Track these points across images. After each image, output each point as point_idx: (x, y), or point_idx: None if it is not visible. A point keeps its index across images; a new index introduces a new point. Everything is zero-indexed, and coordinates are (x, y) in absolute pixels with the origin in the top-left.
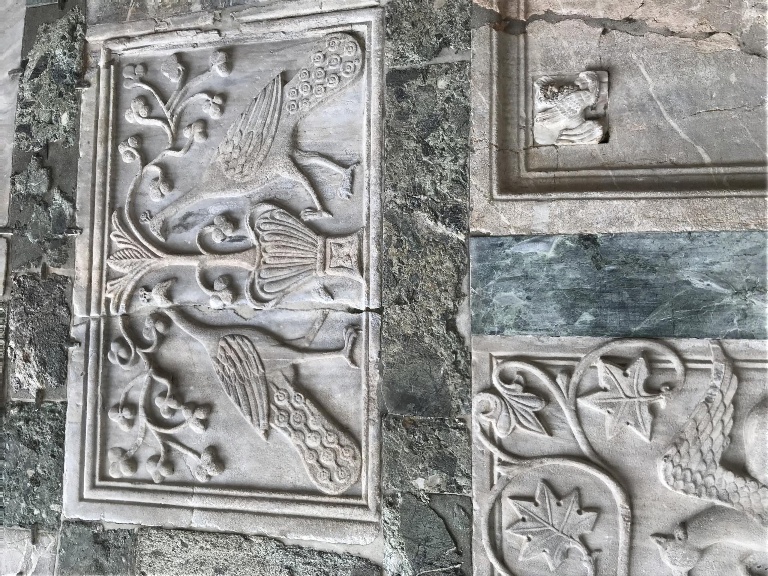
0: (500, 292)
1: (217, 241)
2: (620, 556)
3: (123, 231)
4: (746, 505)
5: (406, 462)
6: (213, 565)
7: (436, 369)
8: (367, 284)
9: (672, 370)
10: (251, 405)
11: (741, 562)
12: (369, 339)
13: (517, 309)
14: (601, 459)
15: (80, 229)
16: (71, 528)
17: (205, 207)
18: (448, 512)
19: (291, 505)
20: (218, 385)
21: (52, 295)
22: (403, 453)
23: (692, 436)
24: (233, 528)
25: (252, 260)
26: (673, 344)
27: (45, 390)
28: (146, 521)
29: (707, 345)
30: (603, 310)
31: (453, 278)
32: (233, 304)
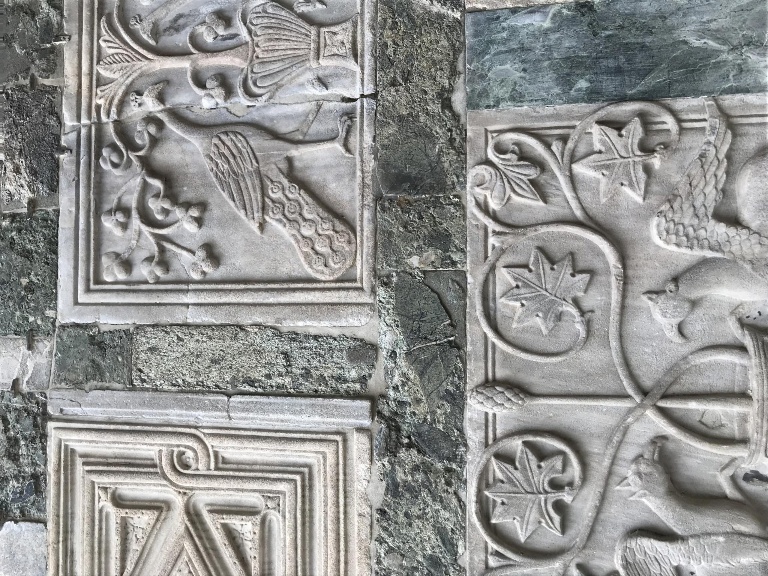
0: (496, 66)
1: (209, 40)
2: (612, 315)
3: (113, 35)
4: (737, 252)
5: (401, 241)
6: (209, 356)
7: (431, 147)
8: (362, 71)
9: (667, 131)
10: (245, 199)
11: (730, 313)
12: (364, 125)
13: (513, 82)
14: (595, 223)
15: (68, 35)
16: (66, 332)
17: (196, 7)
18: (443, 288)
19: (286, 293)
20: (212, 184)
21: (41, 105)
22: (398, 233)
23: (685, 191)
24: (229, 320)
25: (245, 56)
26: (668, 105)
27: (37, 199)
28: (141, 320)
29: (702, 103)
30: (599, 76)
31: (448, 57)
32: (226, 103)
